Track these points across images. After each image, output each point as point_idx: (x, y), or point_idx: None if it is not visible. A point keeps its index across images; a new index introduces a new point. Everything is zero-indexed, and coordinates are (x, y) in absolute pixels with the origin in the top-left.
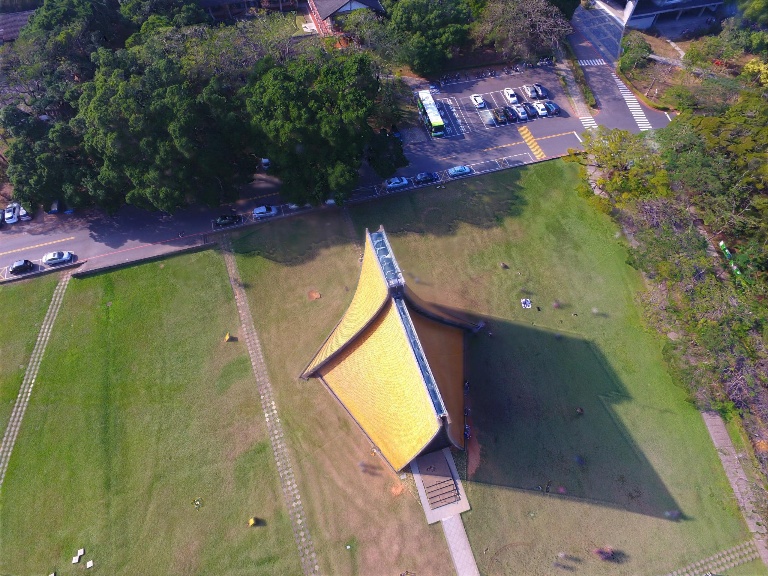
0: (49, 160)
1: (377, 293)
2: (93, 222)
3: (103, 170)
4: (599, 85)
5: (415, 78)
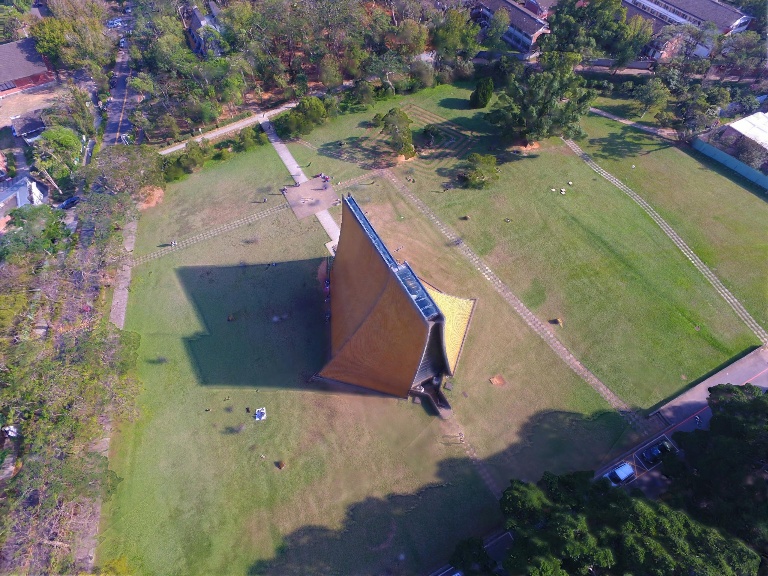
0: None
1: None
2: None
3: None
4: None
5: None
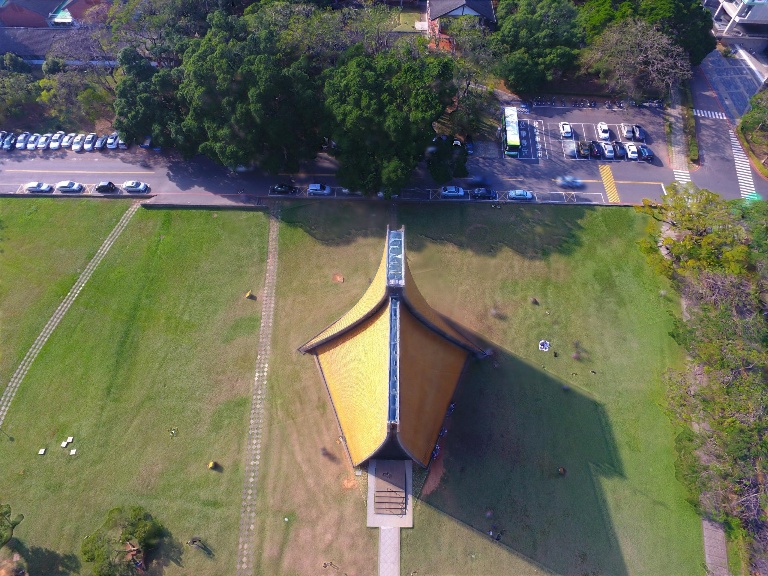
0: (147, 100)
1: (380, 289)
2: (173, 163)
3: (188, 118)
4: (709, 140)
5: (508, 94)
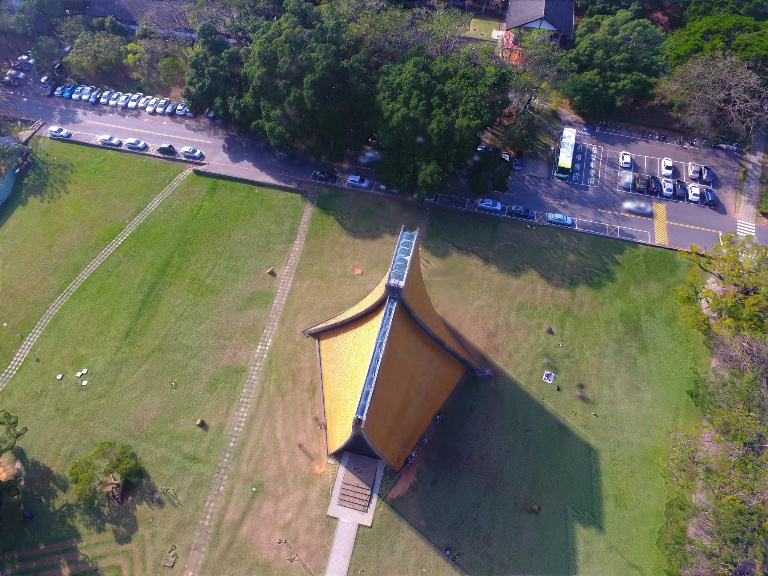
0: (214, 73)
1: (383, 286)
2: (230, 136)
3: (247, 96)
4: None
5: (572, 114)
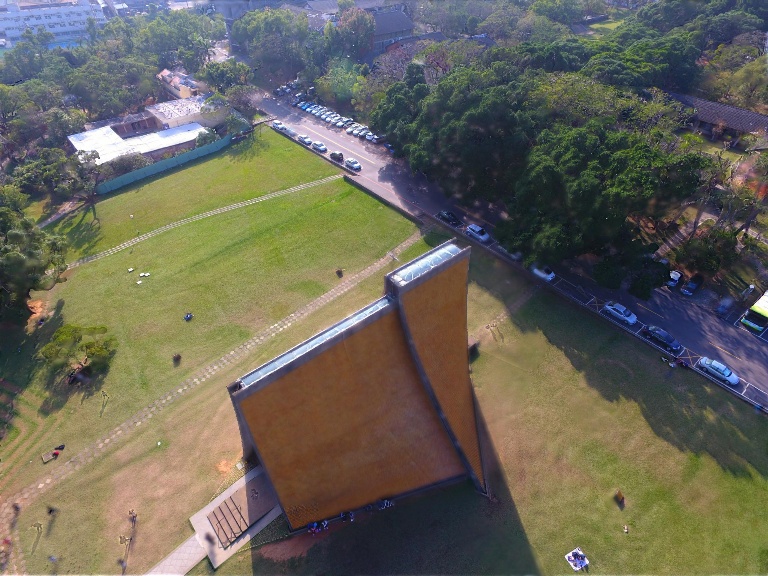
0: (400, 100)
1: None
2: (393, 164)
3: None
4: None
5: None
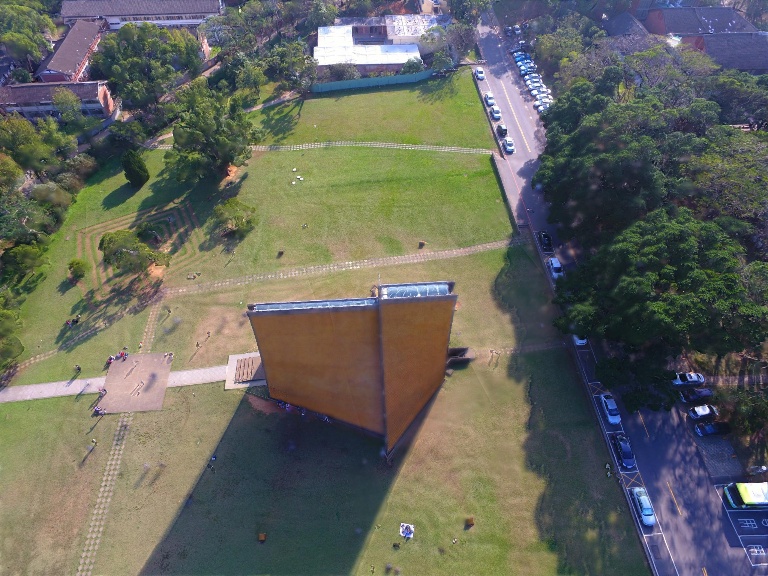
0: (574, 104)
1: None
2: None
3: None
4: None
5: None
